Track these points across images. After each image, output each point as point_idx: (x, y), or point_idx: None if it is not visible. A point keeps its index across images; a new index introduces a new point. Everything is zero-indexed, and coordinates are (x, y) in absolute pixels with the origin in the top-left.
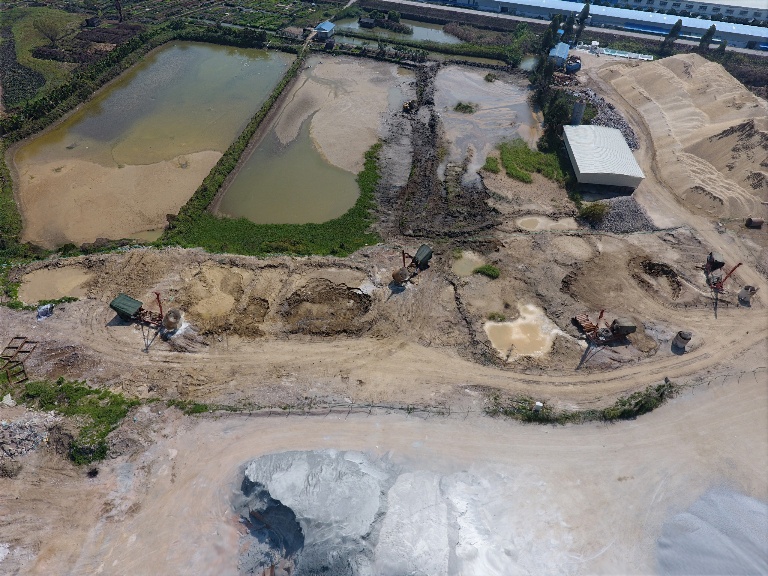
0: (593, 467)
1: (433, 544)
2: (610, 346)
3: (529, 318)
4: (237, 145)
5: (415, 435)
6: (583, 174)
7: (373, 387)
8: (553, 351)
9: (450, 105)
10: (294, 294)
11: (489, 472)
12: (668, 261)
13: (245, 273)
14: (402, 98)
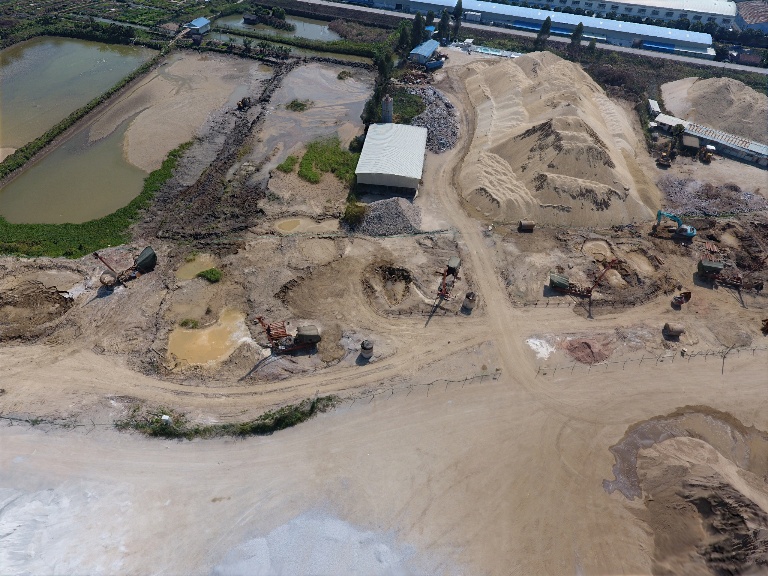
0: (193, 486)
1: None
2: (292, 355)
3: (225, 325)
4: (34, 142)
5: (23, 449)
6: (358, 174)
7: (12, 397)
8: (227, 360)
9: (284, 103)
10: None
11: (77, 491)
12: (411, 266)
13: None
14: (245, 95)
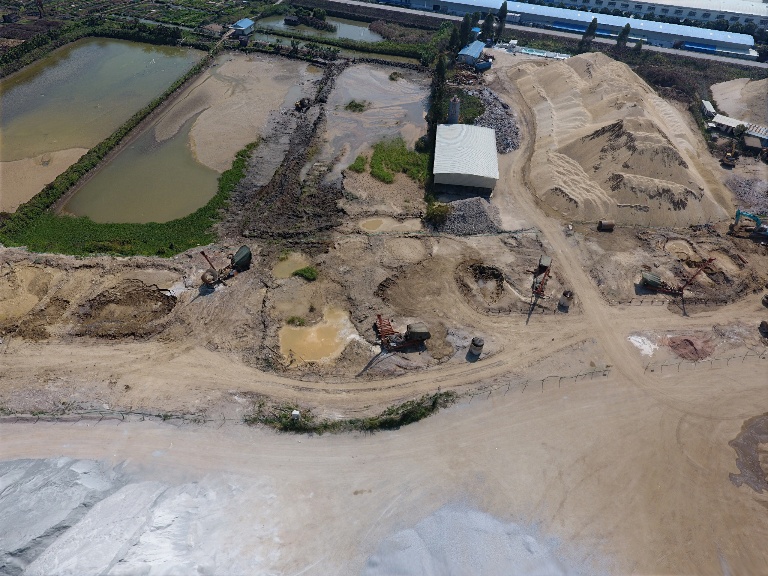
0: (333, 479)
1: (86, 561)
2: (403, 352)
3: (331, 322)
4: (105, 142)
5: (160, 444)
6: (436, 174)
7: (138, 393)
8: (340, 357)
9: (342, 103)
10: (100, 295)
11: (221, 483)
12: (500, 264)
13: (57, 273)
14: (300, 96)
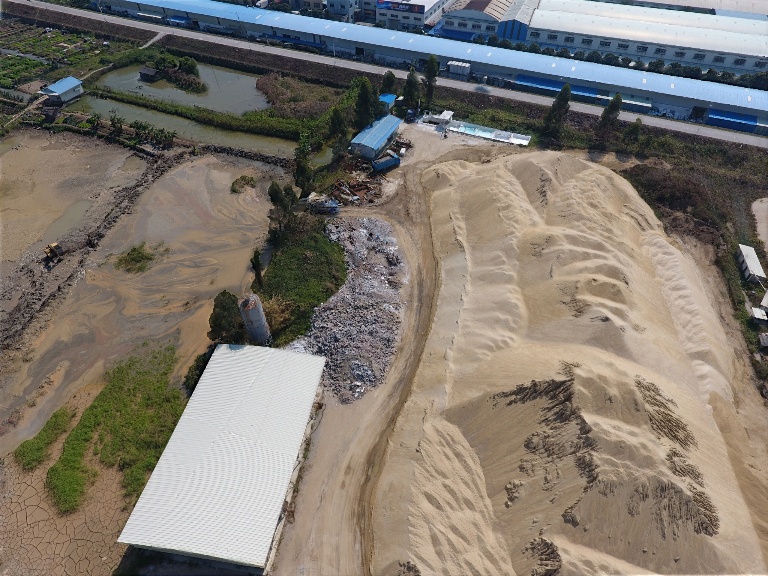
0: None
1: None
2: None
3: None
4: None
5: None
6: (125, 542)
7: None
8: None
9: (120, 250)
10: None
11: None
12: None
13: None
14: (75, 224)
